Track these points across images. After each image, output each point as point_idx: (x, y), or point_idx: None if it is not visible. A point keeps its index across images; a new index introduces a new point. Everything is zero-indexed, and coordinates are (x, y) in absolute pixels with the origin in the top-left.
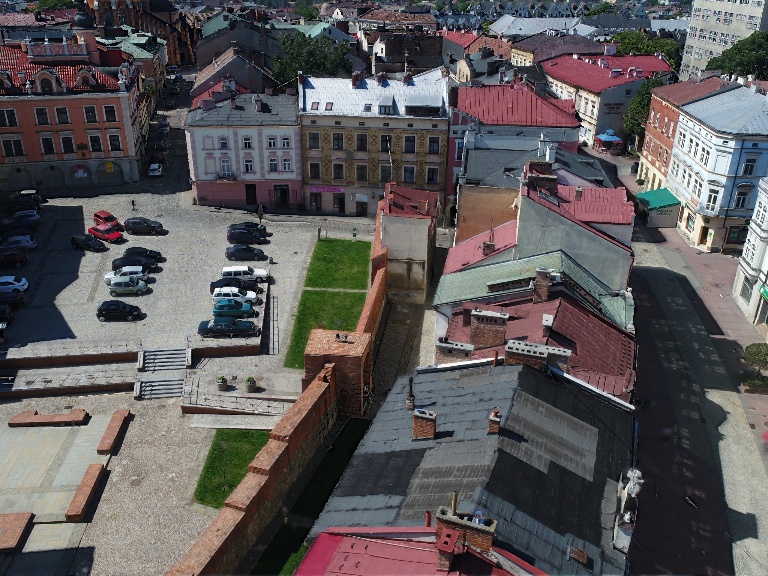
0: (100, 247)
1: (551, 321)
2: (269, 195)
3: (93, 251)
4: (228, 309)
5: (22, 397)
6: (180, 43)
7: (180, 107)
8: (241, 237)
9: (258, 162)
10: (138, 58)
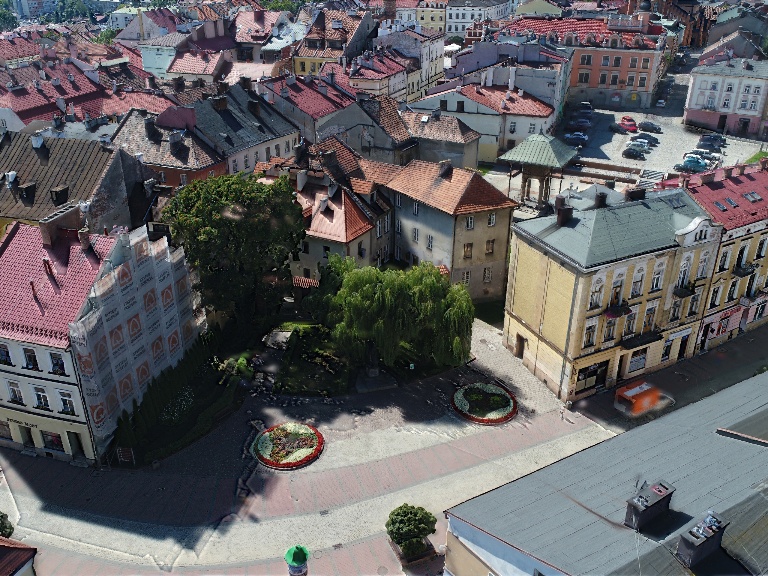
0: (624, 132)
1: None
2: (735, 124)
3: (620, 133)
4: (693, 163)
5: (584, 176)
6: (694, 30)
7: (684, 73)
8: (709, 141)
9: (734, 101)
10: None
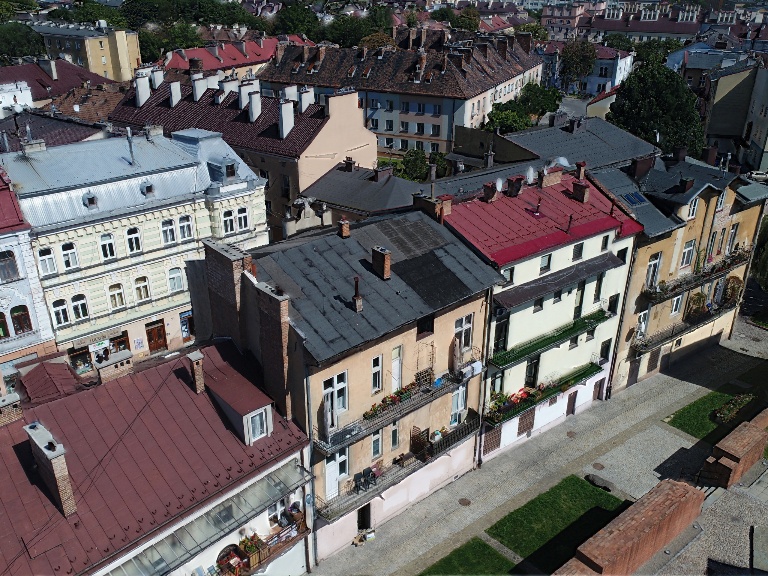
0: None
1: (3, 397)
2: None
3: None
4: None
5: None
6: None
7: None
8: None
9: None
10: None
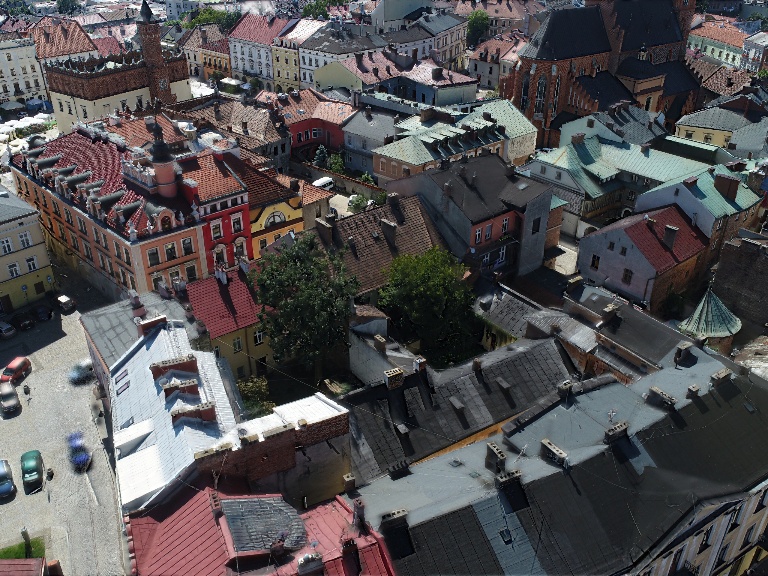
0: None
1: None
2: None
3: None
4: None
5: None
6: None
7: None
8: None
9: None
10: (404, 161)
